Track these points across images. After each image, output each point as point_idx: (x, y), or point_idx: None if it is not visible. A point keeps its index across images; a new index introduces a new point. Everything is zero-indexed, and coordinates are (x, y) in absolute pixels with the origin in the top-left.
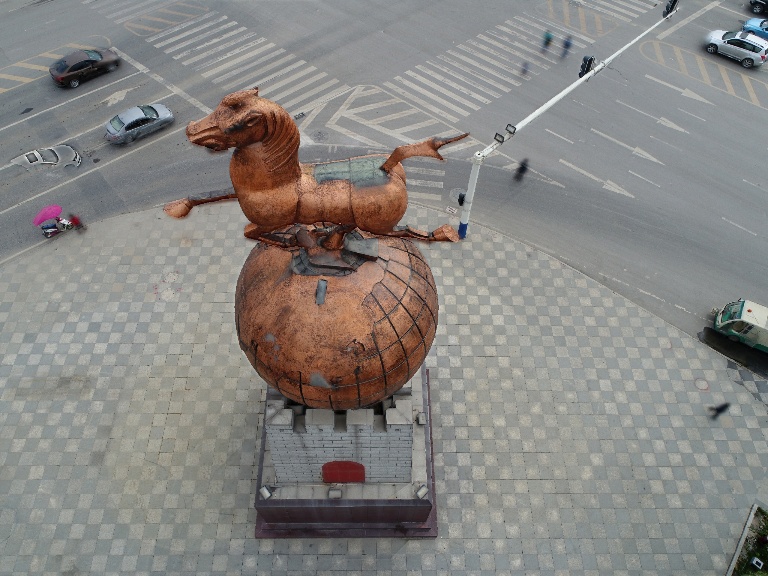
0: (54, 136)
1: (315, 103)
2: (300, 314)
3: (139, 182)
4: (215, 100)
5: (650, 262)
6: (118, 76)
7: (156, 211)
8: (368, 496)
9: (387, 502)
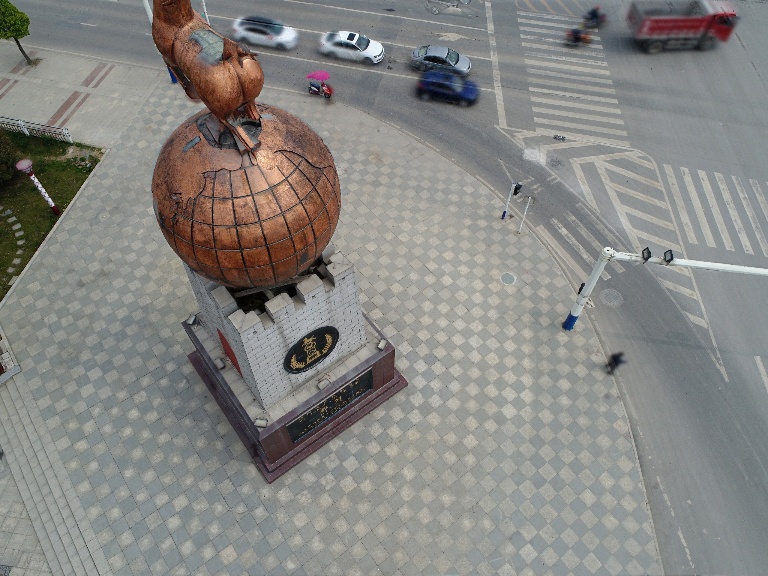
0: (386, 36)
1: (584, 137)
2: (172, 149)
3: (397, 100)
4: (512, 83)
5: (728, 523)
6: (469, 24)
7: (383, 125)
8: (234, 387)
9: (239, 404)
